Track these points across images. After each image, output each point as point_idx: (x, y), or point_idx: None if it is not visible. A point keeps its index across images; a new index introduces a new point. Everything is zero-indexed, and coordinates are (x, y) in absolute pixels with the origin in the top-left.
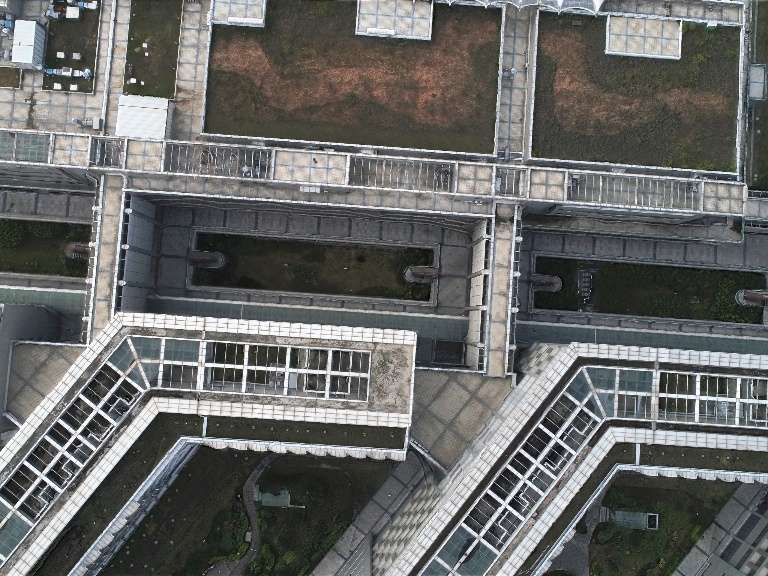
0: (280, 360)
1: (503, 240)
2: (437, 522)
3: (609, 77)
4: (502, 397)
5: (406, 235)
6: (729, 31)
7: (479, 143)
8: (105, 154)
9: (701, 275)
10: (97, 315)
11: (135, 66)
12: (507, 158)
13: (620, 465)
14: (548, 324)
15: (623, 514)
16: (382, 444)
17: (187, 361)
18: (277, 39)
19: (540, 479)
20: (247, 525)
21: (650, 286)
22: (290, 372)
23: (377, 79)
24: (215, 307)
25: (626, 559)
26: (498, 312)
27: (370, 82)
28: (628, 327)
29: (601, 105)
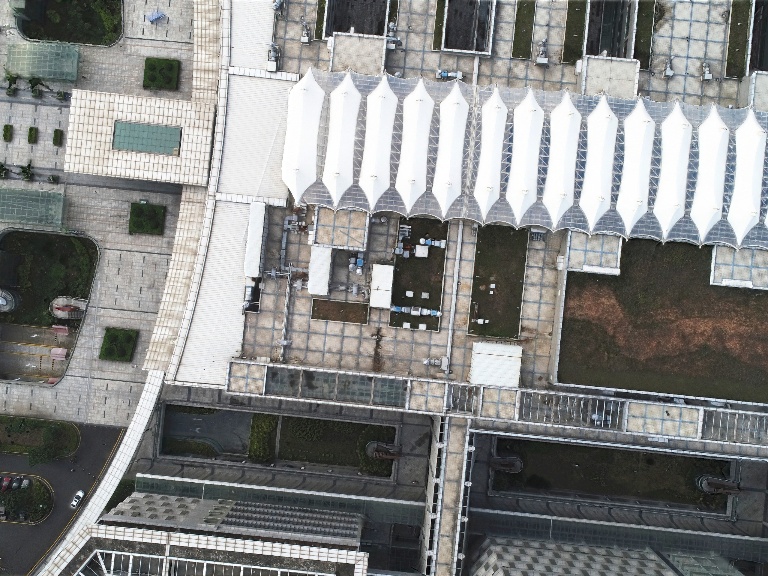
0: None
1: None
2: None
3: None
4: None
5: None
6: None
7: None
8: (453, 395)
9: None
10: (441, 550)
11: (480, 304)
12: None
13: None
14: None
15: None
16: None
17: None
18: (631, 287)
19: None
20: None
21: None
22: None
23: (731, 330)
24: (525, 521)
25: None
26: None
27: (723, 333)
28: None
29: None
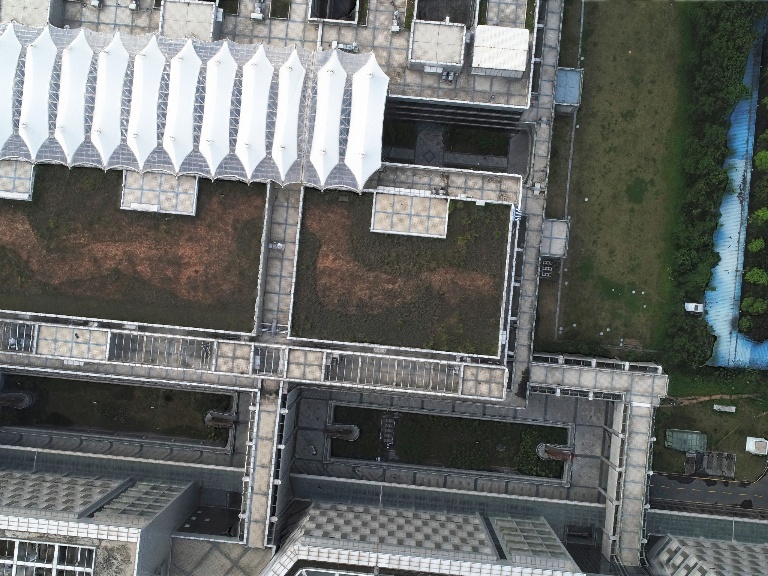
0: (9, 552)
1: (268, 413)
2: None
3: (373, 255)
4: (261, 568)
5: None
6: (499, 209)
7: (240, 320)
8: None
9: (502, 427)
10: None
11: None
12: (273, 331)
13: None
14: (335, 479)
15: None
16: None
17: None
18: (44, 213)
19: None
20: None
21: (455, 433)
22: (18, 565)
23: (141, 254)
24: (10, 453)
25: None
26: (260, 484)
27: (134, 257)
28: (415, 484)
29: (364, 284)
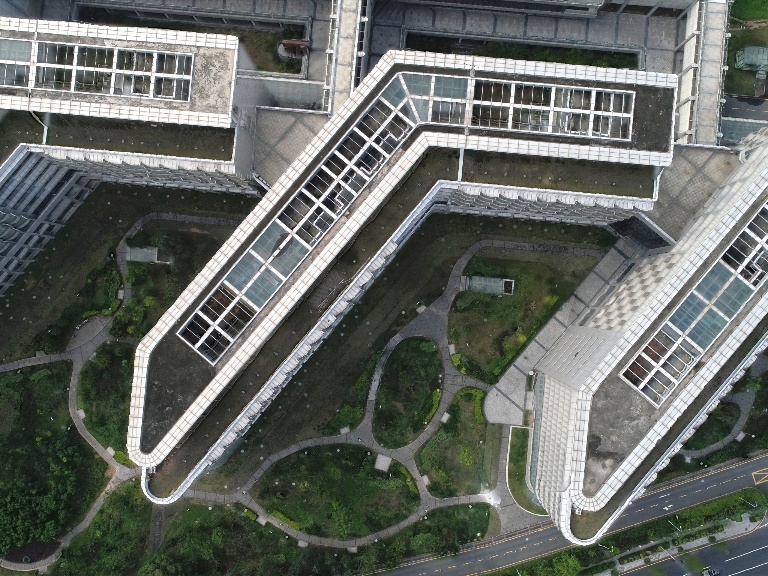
0: (108, 62)
1: None
2: (252, 217)
3: None
4: None
5: (279, 10)
6: None
7: None
8: None
9: (573, 55)
10: None
11: None
12: None
13: (440, 180)
14: None
15: (480, 279)
16: (212, 156)
17: (20, 61)
18: None
19: (354, 180)
20: (119, 282)
21: None
22: (117, 73)
23: None
24: None
25: (483, 326)
26: (344, 55)
27: None
28: None
29: None
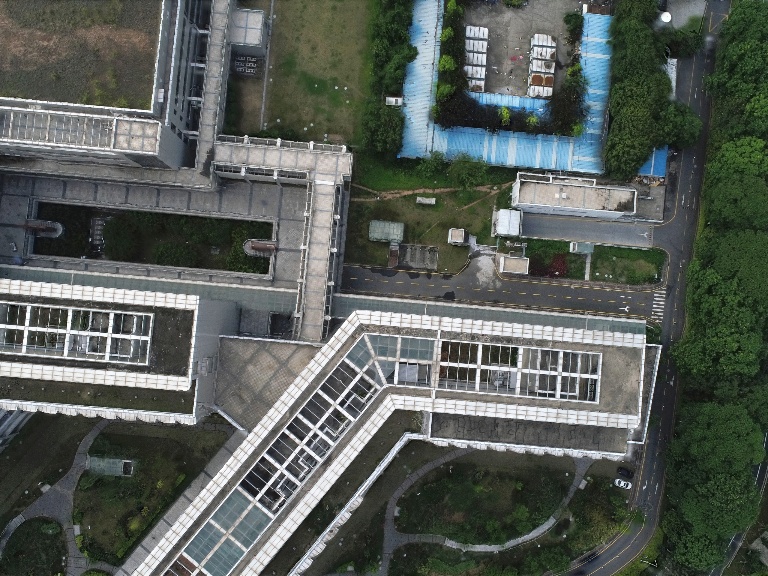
0: None
1: None
2: None
3: (28, 12)
4: None
5: None
6: None
7: None
8: None
9: (209, 224)
10: None
11: None
12: None
13: None
14: (25, 268)
15: (98, 460)
16: None
17: None
18: None
19: None
20: None
21: (168, 235)
22: None
23: None
24: None
25: (108, 506)
26: None
27: None
28: (108, 272)
29: (19, 41)
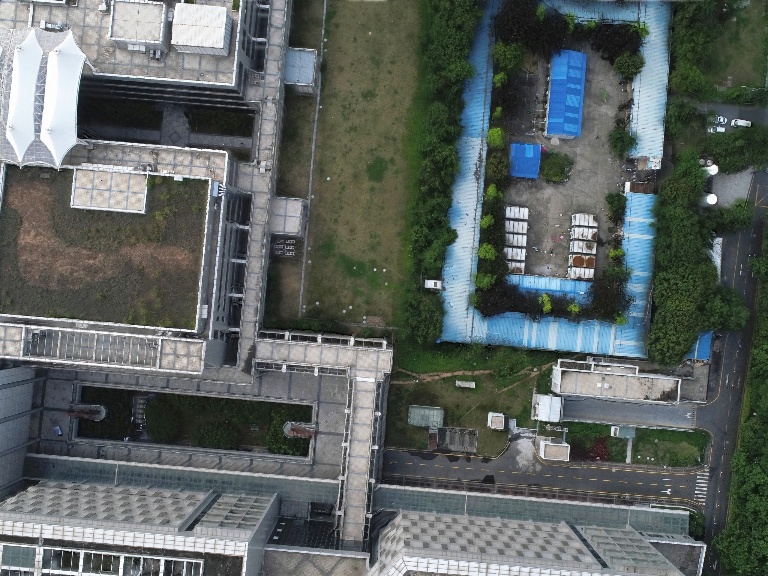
0: None
1: None
2: None
3: (74, 231)
4: None
5: None
6: (199, 184)
7: None
8: None
9: (249, 405)
10: None
11: None
12: None
13: None
14: (71, 459)
15: None
16: None
17: None
18: None
19: None
20: None
21: (208, 412)
22: None
23: None
24: None
25: None
26: None
27: None
28: (151, 463)
29: (65, 259)
